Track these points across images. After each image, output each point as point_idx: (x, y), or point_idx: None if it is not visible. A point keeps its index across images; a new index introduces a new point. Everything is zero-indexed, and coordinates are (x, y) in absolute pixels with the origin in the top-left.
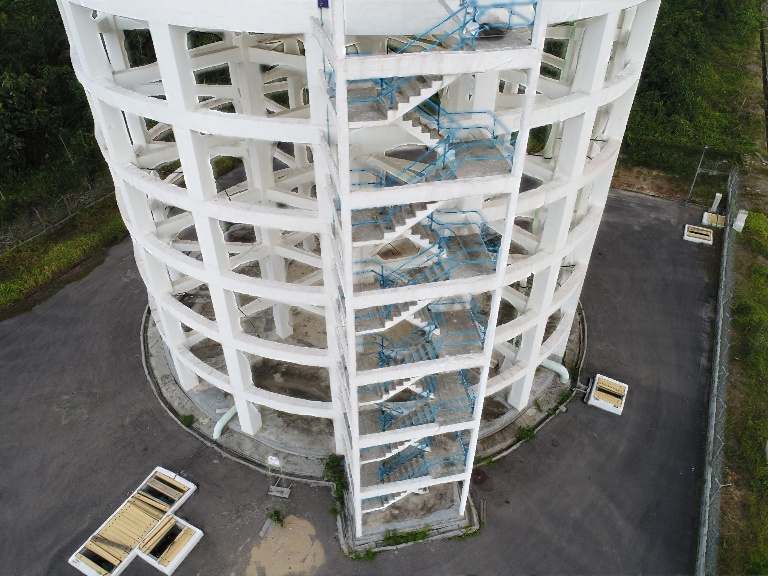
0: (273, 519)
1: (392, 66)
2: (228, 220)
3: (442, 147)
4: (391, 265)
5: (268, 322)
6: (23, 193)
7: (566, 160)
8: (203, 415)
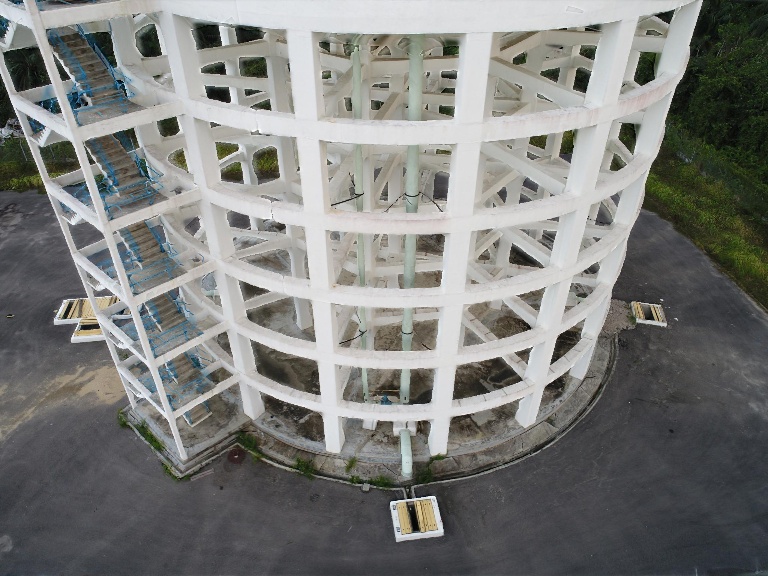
0: (120, 357)
1: None
2: None
3: None
4: None
5: (305, 264)
6: None
7: None
8: None
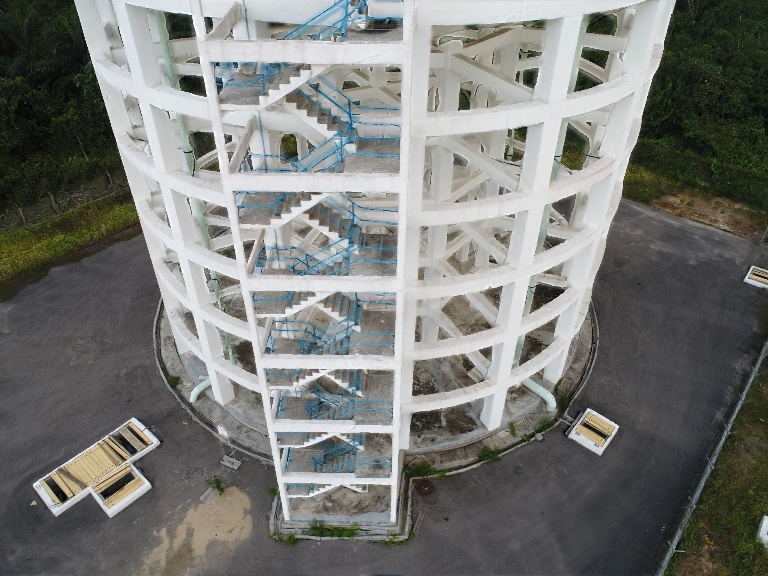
0: (212, 486)
1: (254, 51)
2: (185, 194)
3: (339, 140)
4: None
5: None
6: (108, 157)
7: (528, 172)
8: (188, 379)
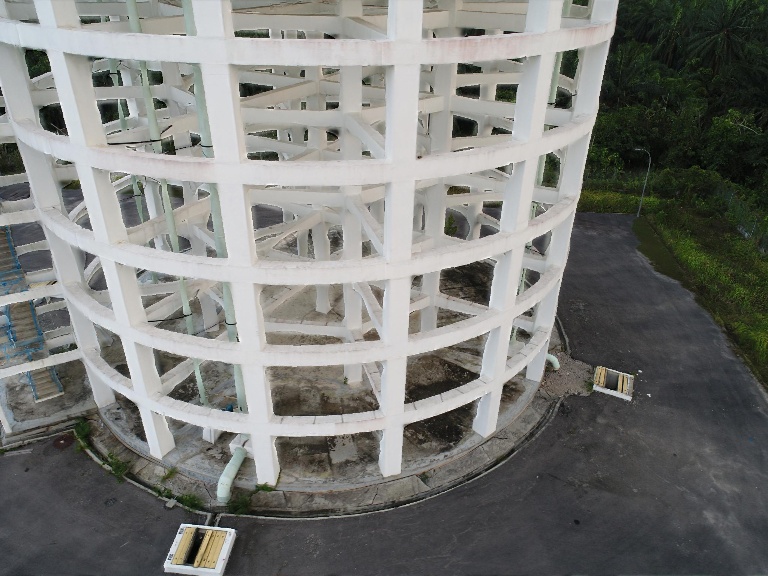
0: None
1: None
2: None
3: None
4: (207, 238)
5: None
6: None
7: None
8: None
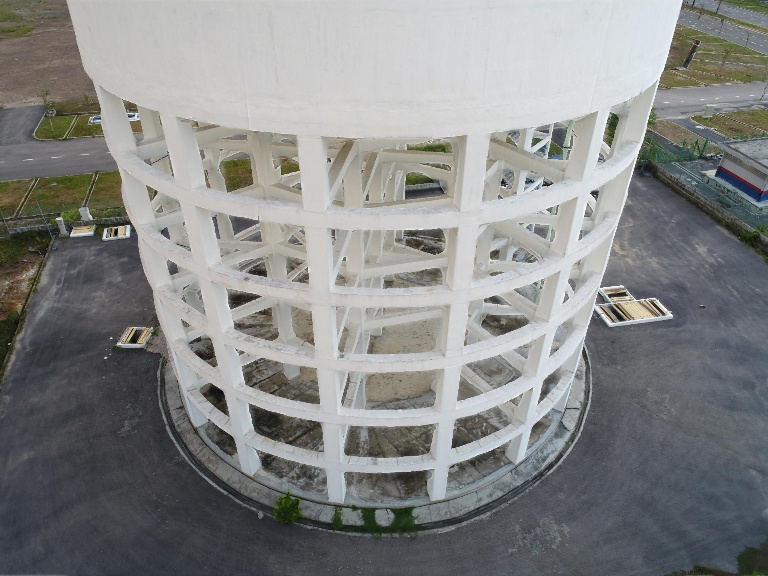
0: None
1: None
2: None
3: None
4: None
5: None
6: None
7: None
8: None
